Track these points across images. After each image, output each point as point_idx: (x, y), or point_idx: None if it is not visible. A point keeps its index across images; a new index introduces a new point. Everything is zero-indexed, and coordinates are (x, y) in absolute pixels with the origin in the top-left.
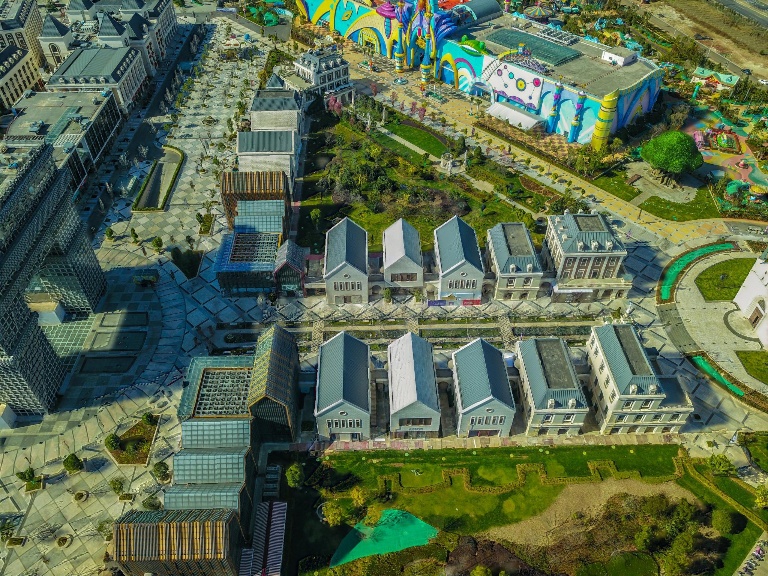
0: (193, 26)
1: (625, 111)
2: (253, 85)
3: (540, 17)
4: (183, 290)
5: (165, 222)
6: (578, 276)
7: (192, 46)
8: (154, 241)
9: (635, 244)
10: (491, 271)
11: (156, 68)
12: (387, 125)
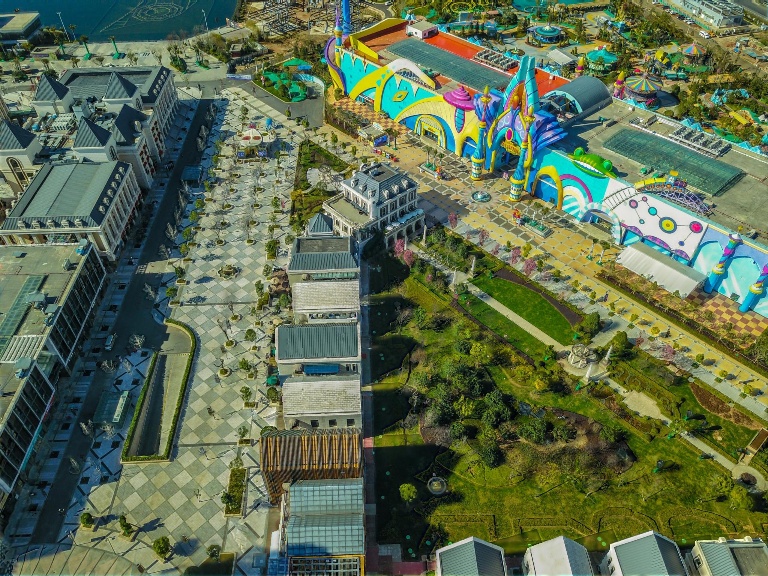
0: (198, 102)
1: None
2: (284, 205)
3: (647, 93)
4: None
5: (172, 485)
6: None
7: (199, 143)
8: (156, 547)
9: None
10: None
11: (153, 174)
12: (477, 279)
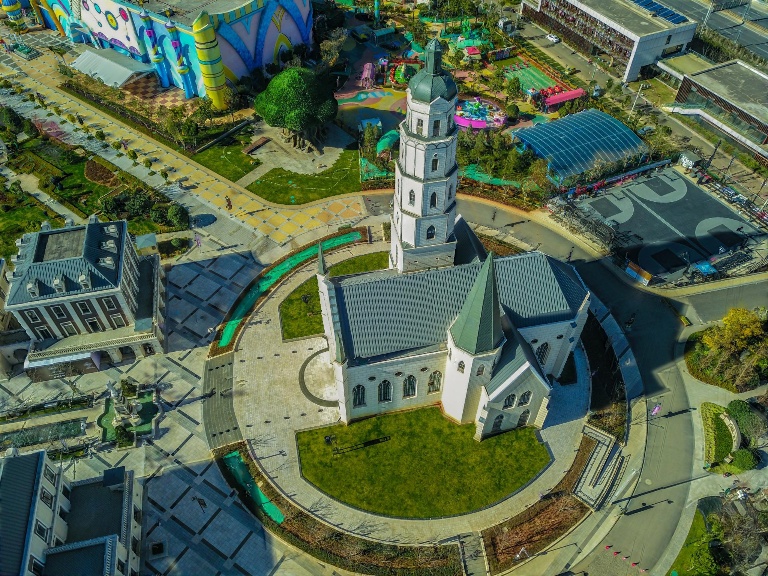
0: None
1: (252, 45)
2: None
3: None
4: None
5: None
6: (70, 332)
7: None
8: None
9: (216, 252)
10: None
11: None
12: None
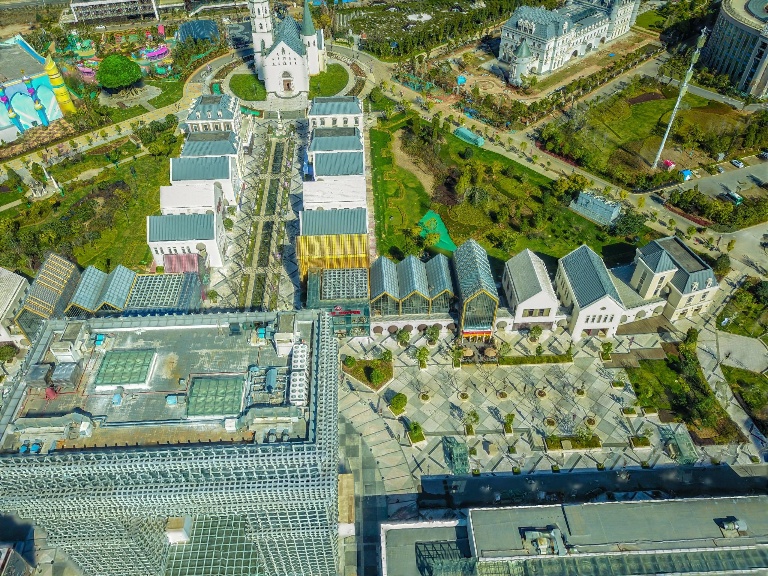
0: None
1: None
2: None
3: None
4: None
5: None
6: None
7: None
8: None
9: None
10: None
11: None
12: None
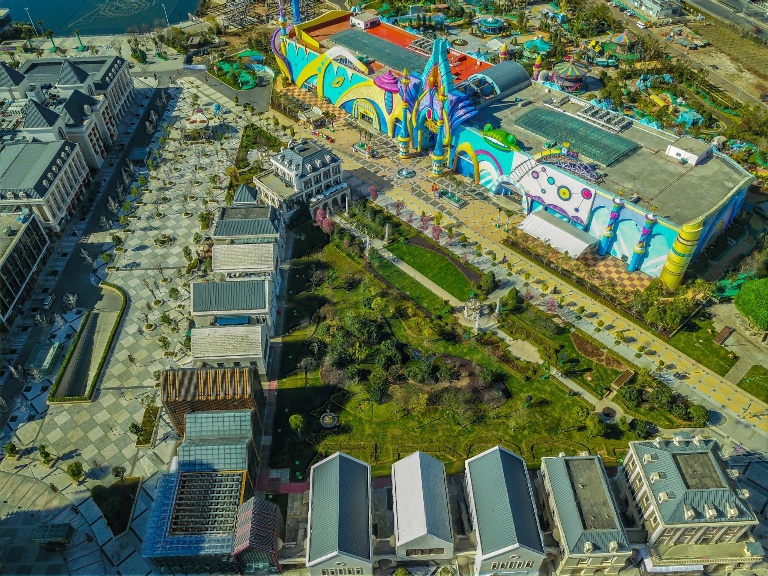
0: (154, 91)
1: (705, 233)
2: (221, 182)
3: (573, 78)
4: (106, 558)
5: (92, 421)
6: (679, 541)
7: (148, 126)
8: (69, 470)
9: (745, 457)
10: (550, 527)
11: (103, 156)
12: (391, 245)
